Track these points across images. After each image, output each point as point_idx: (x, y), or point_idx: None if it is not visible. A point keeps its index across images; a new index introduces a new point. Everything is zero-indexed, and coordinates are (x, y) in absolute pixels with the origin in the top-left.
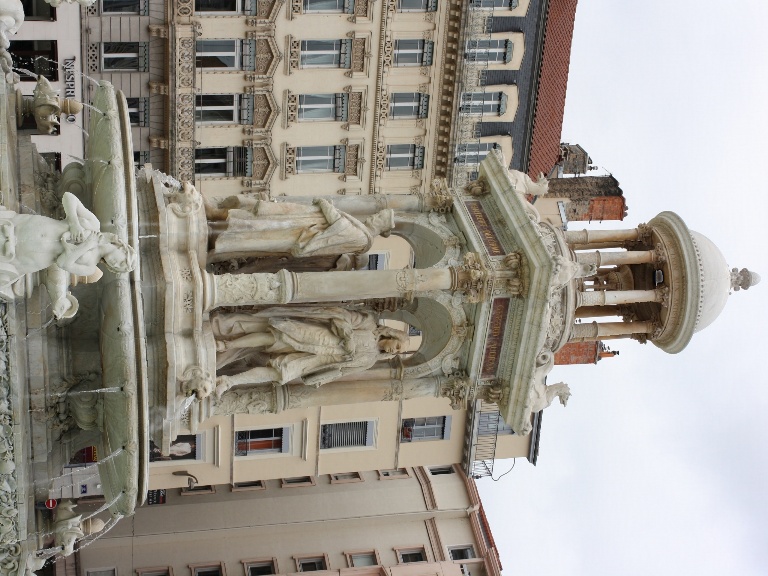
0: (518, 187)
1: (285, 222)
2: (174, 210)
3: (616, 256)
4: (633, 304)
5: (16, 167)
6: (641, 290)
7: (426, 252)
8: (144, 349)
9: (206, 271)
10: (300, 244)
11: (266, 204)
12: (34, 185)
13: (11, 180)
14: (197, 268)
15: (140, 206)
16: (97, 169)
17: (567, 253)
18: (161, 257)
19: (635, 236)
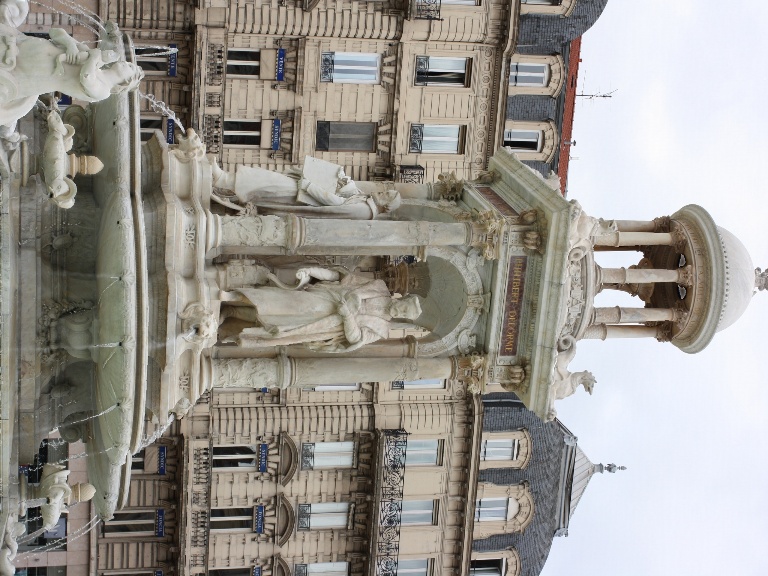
0: None
1: (300, 341)
2: (184, 338)
3: (636, 320)
4: (654, 249)
5: (17, 329)
6: (645, 331)
7: (452, 270)
8: None
9: (206, 366)
10: (310, 348)
11: (284, 335)
12: (35, 353)
13: (11, 431)
14: (197, 376)
15: (149, 327)
16: (104, 407)
17: (586, 323)
18: (161, 382)
19: (674, 281)
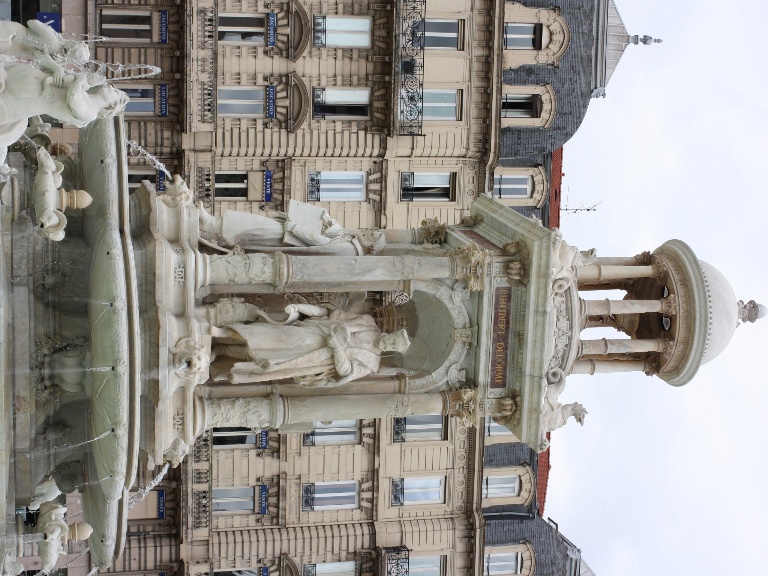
0: (560, 272)
1: (291, 375)
2: (177, 373)
3: (622, 351)
4: (637, 287)
5: (11, 364)
6: (632, 365)
7: (438, 307)
8: (124, 539)
9: (199, 406)
10: (301, 383)
11: (275, 368)
12: None
13: (7, 465)
14: (190, 415)
15: (141, 364)
16: None
17: (574, 355)
18: (155, 421)
19: (658, 311)
